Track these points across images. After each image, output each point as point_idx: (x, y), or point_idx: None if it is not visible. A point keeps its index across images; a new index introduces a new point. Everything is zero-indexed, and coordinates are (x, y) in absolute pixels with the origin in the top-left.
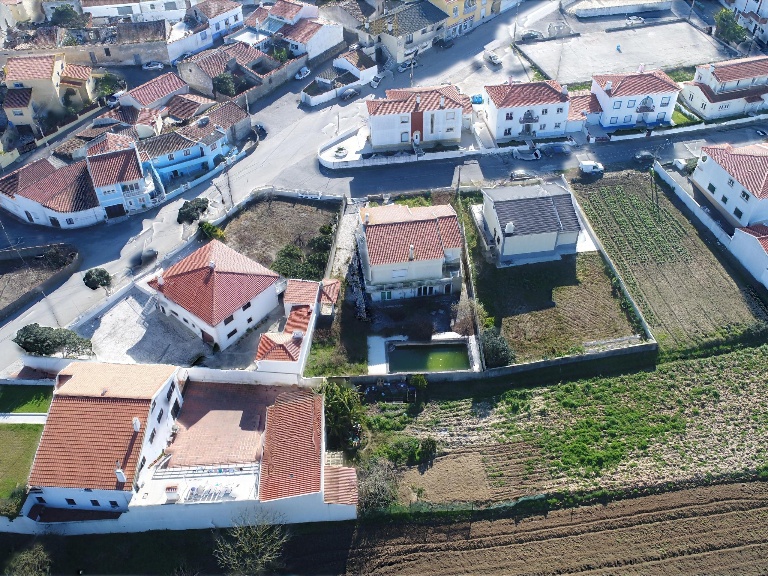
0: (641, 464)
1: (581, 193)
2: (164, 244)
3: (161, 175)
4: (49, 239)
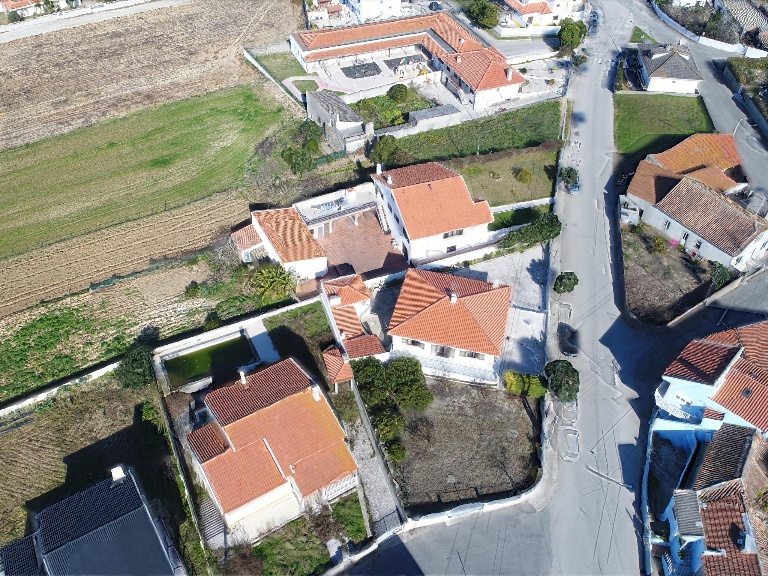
0: (3, 332)
1: None
2: None
3: (683, 434)
4: (701, 336)
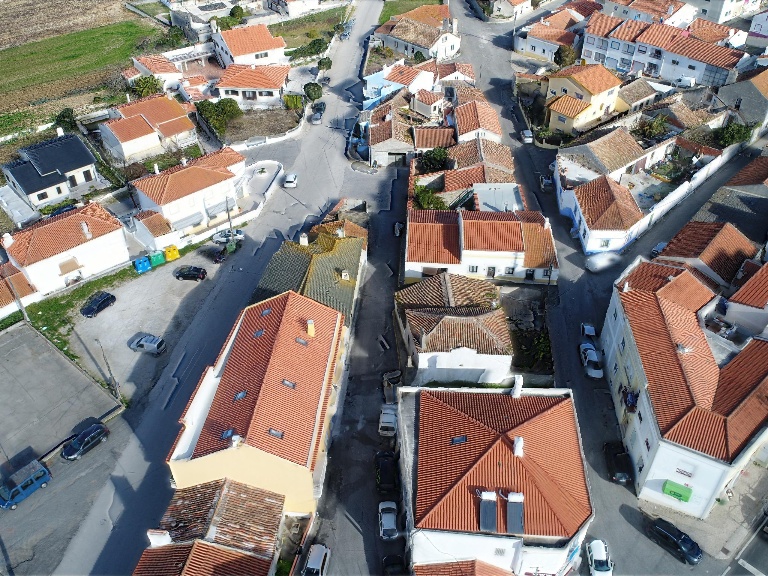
0: None
1: (1, 226)
2: (327, 99)
3: None
4: None
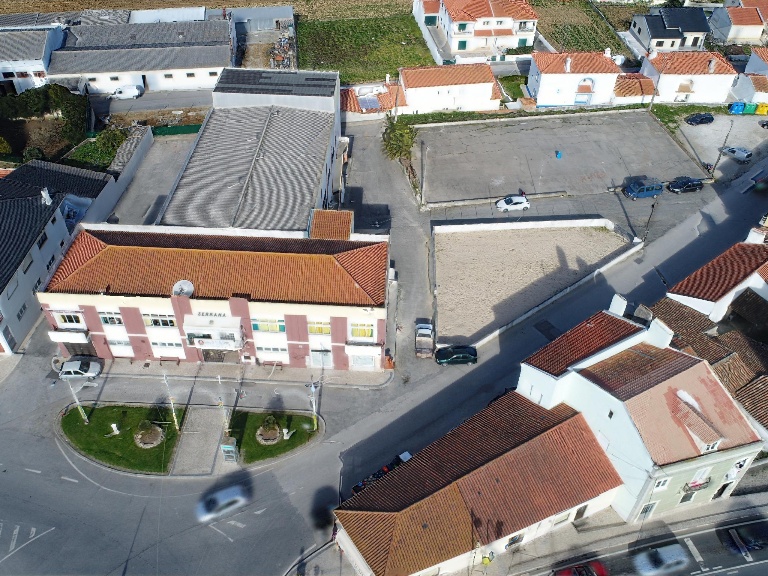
0: None
1: (623, 55)
2: None
3: None
4: None
